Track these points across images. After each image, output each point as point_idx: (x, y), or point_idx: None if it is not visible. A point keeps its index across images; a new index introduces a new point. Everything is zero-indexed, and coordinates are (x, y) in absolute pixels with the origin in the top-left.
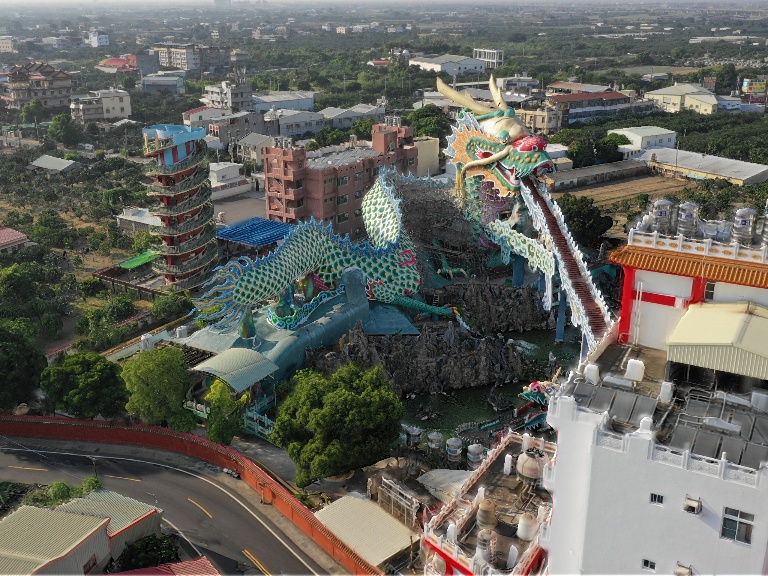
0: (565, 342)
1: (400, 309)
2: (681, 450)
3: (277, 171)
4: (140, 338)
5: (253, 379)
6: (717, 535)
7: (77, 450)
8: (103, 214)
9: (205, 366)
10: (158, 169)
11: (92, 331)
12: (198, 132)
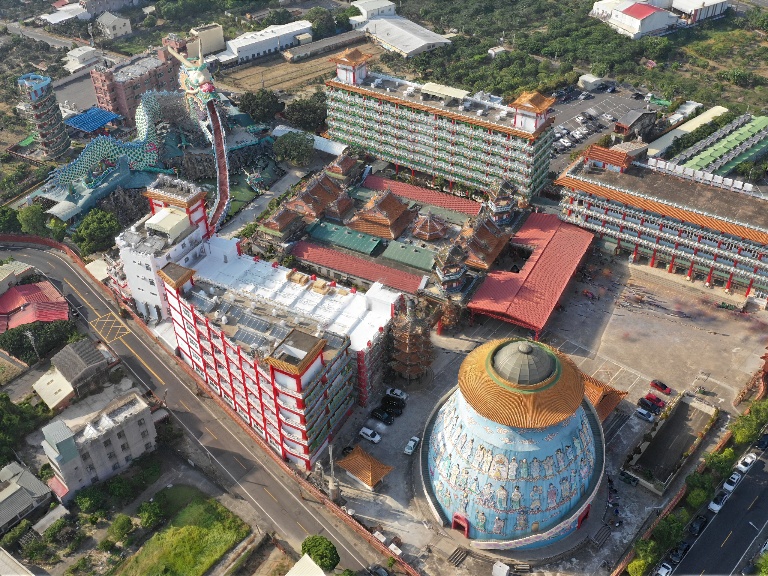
0: None
1: (149, 172)
2: (138, 251)
3: (99, 84)
4: (31, 189)
5: (71, 215)
6: (146, 269)
7: (6, 245)
8: (9, 98)
9: (51, 211)
10: (28, 101)
11: (7, 190)
12: (46, 82)
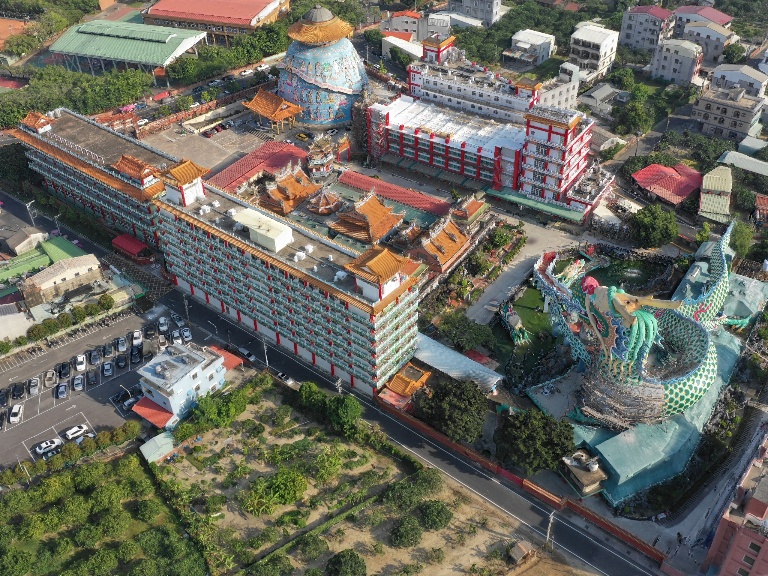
0: (552, 335)
1: None
2: None
3: None
4: None
5: None
6: None
7: None
8: None
9: None
10: None
11: None
12: None
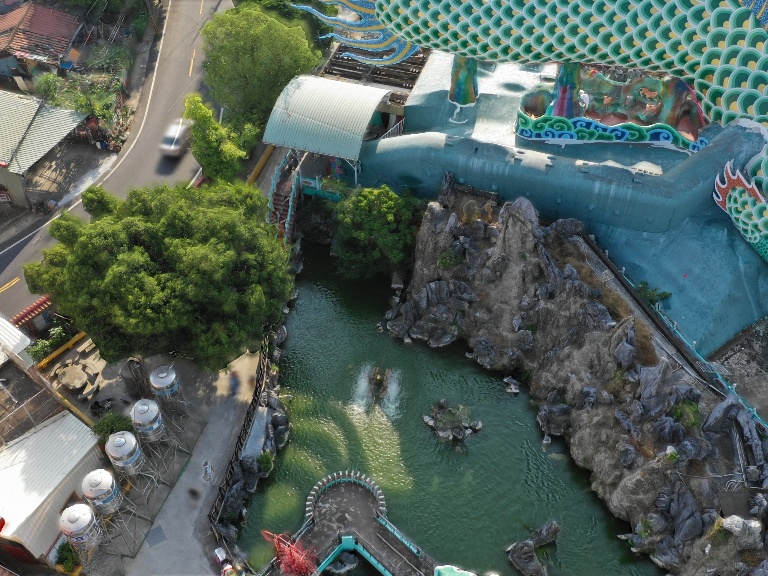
0: None
1: None
2: None
3: None
4: None
5: (302, 142)
6: None
7: None
8: None
9: (305, 83)
10: None
11: None
12: None
